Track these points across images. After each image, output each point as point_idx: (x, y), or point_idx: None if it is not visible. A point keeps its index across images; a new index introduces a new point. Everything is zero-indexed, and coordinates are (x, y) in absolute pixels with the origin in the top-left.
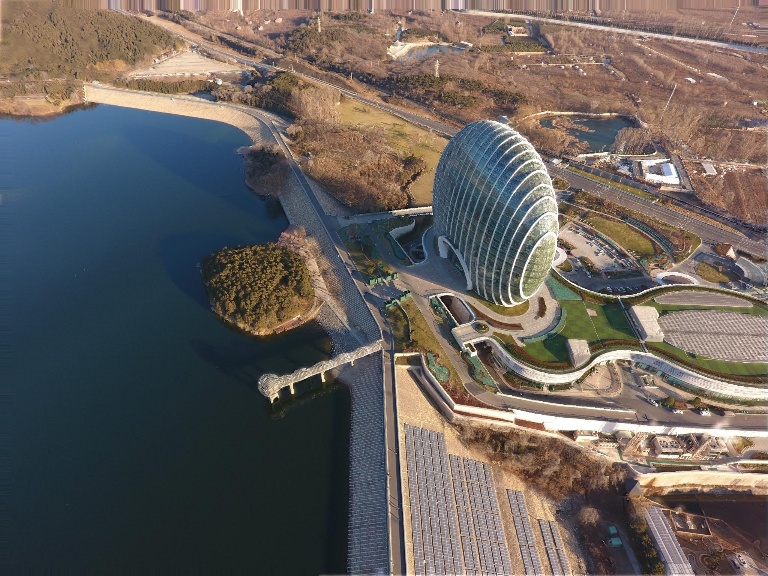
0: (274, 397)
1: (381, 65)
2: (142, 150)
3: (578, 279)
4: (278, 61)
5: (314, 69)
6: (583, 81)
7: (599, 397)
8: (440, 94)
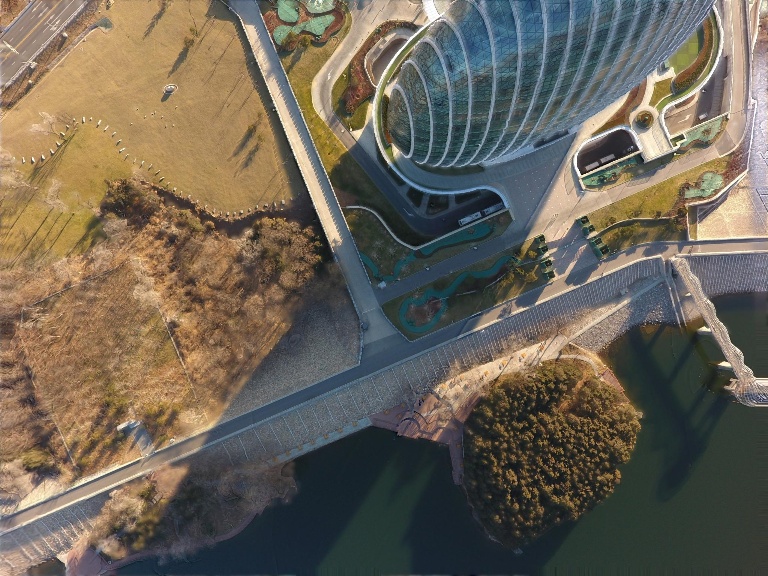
0: None
1: None
2: None
3: None
4: None
5: None
6: None
7: None
8: None
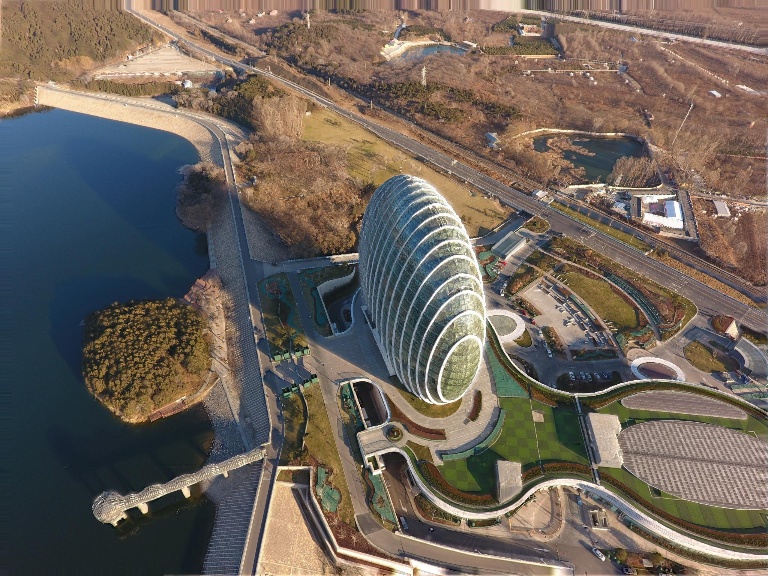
0: (117, 519)
1: (367, 68)
2: (77, 165)
3: (536, 358)
4: (257, 61)
5: (292, 72)
6: (591, 92)
7: (530, 540)
8: (423, 106)
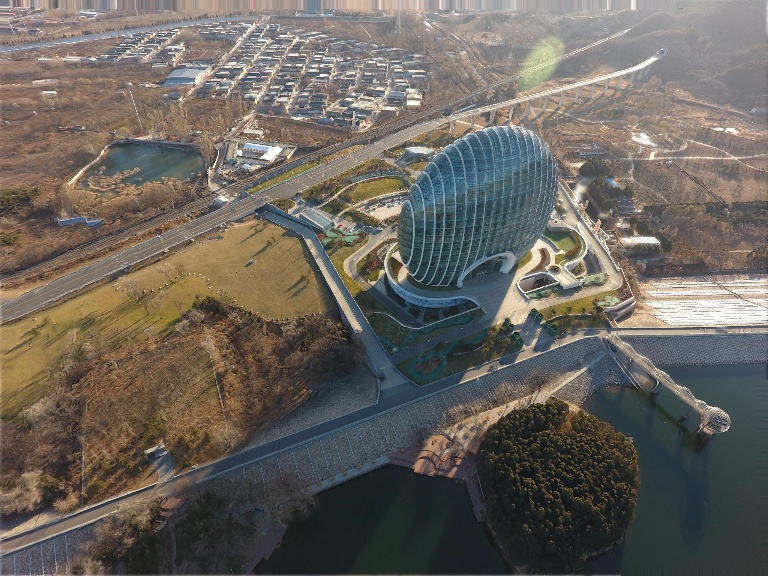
0: None
1: None
2: None
3: None
4: None
5: None
6: None
7: None
8: None
